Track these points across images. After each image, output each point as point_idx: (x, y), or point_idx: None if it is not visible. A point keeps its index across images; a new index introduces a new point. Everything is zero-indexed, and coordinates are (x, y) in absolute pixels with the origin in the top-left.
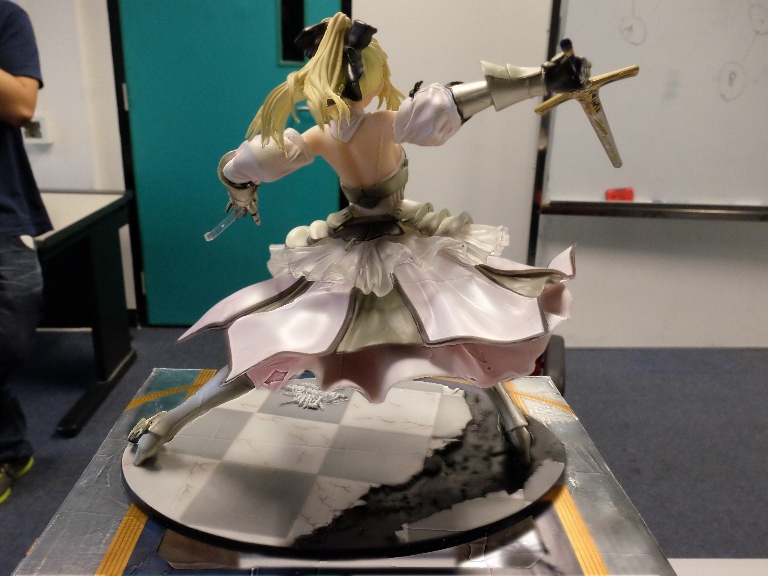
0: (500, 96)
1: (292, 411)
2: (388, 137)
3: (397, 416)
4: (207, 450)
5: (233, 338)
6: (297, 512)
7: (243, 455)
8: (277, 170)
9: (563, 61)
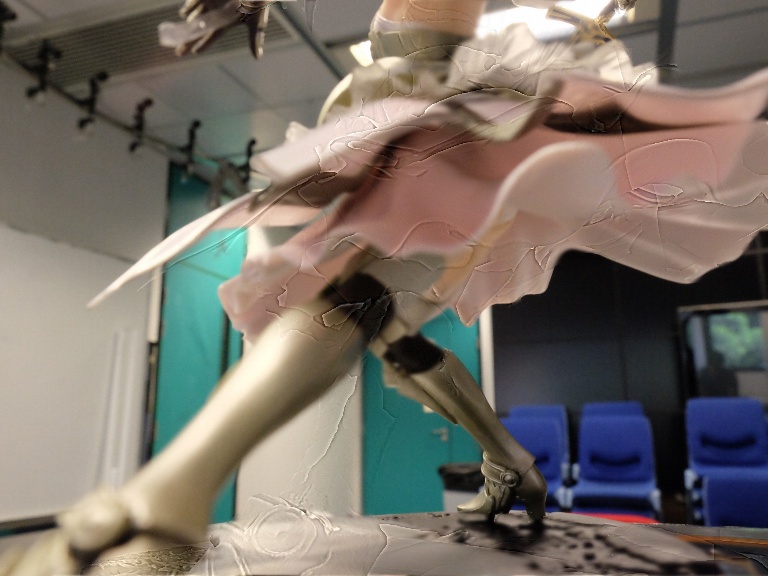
0: None
1: None
2: None
3: None
4: None
5: None
6: None
7: None
8: None
9: None
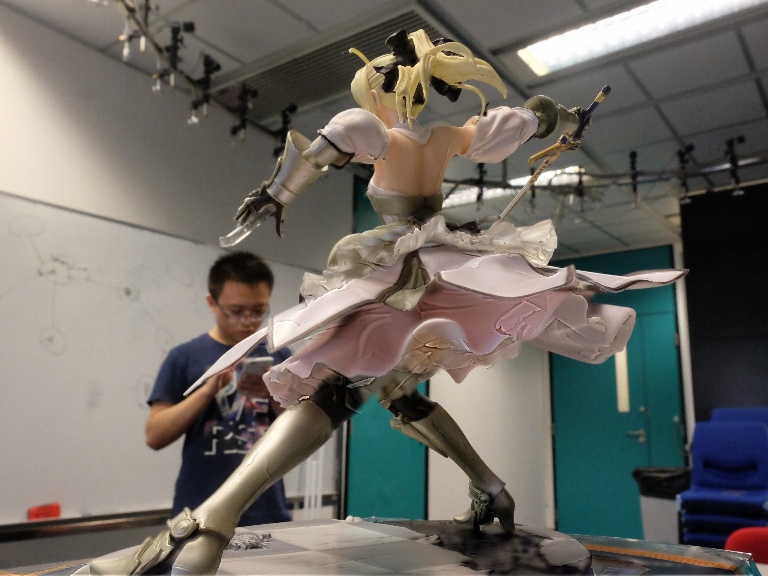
0: (559, 122)
1: (238, 553)
2: (455, 148)
3: (347, 538)
4: None
5: (462, 283)
6: None
7: None
8: (383, 147)
9: (581, 111)
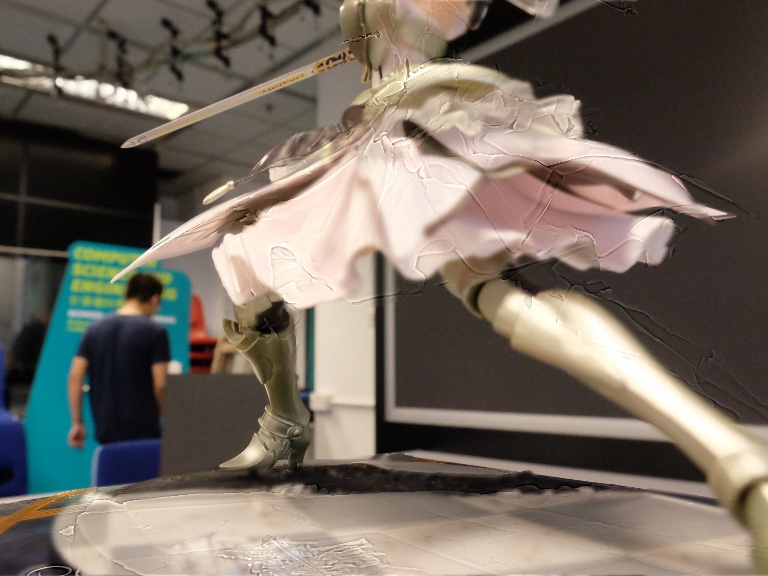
0: None
1: (421, 561)
2: None
3: None
4: (723, 557)
5: None
6: (617, 495)
7: (640, 538)
8: None
9: None
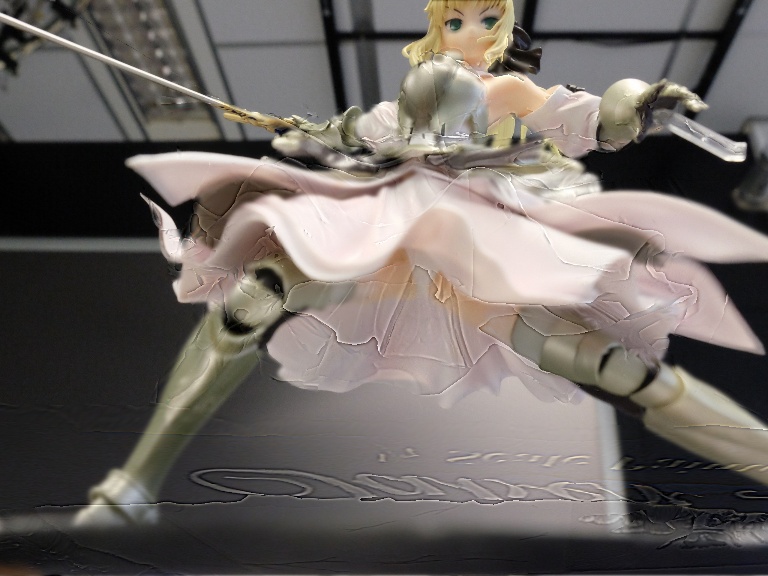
0: None
1: None
2: None
3: (363, 552)
4: None
5: None
6: None
7: None
8: None
9: None
